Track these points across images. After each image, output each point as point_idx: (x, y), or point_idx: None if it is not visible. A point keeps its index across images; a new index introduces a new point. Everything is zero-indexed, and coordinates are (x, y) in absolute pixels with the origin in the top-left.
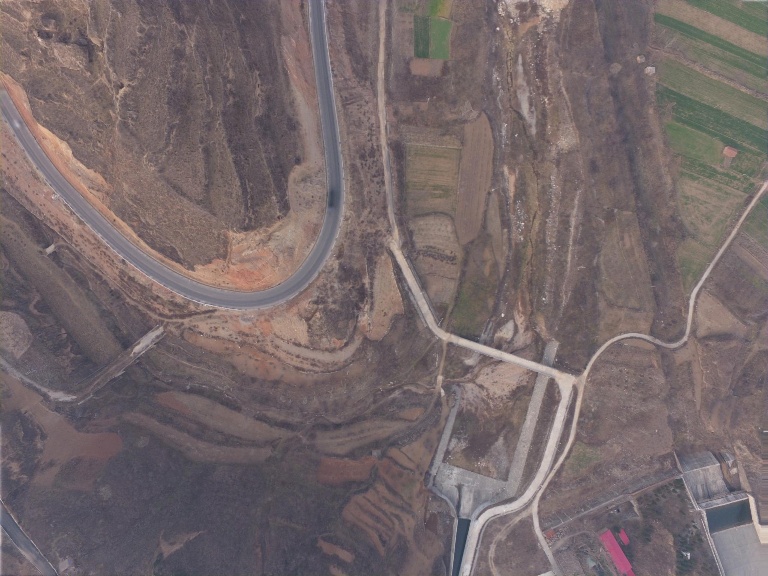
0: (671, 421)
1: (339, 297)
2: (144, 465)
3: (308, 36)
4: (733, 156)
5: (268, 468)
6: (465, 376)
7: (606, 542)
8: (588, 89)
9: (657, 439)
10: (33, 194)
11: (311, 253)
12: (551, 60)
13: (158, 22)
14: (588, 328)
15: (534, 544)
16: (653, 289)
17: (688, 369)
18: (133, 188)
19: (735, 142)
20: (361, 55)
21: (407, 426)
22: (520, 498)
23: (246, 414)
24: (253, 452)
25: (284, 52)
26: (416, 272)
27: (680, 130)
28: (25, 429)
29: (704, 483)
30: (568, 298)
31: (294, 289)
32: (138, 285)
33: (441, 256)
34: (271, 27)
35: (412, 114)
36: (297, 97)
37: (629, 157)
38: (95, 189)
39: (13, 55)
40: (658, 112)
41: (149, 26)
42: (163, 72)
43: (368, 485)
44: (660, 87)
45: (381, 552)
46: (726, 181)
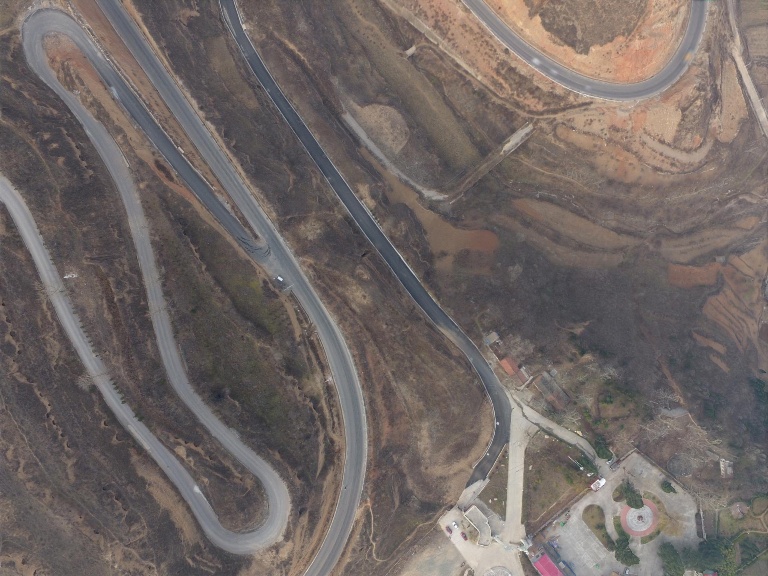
0: None
1: None
2: None
3: None
4: None
5: (623, 272)
6: None
7: None
8: None
9: None
10: None
11: (680, 47)
12: None
13: None
14: None
15: None
16: None
17: None
18: None
19: None
20: None
21: (744, 235)
22: None
23: (610, 213)
24: (606, 258)
25: None
26: None
27: None
28: (414, 220)
29: None
30: None
31: (666, 81)
32: (518, 76)
33: None
34: None
35: None
36: None
37: None
38: None
39: None
40: None
41: None
42: None
43: (718, 288)
44: None
45: (740, 350)
46: None
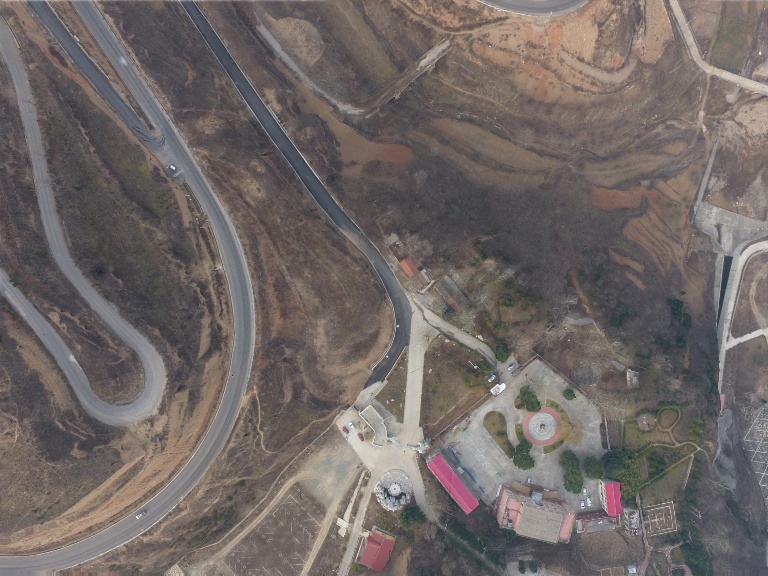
0: None
1: None
2: (437, 173)
3: None
4: None
5: (544, 193)
6: (725, 113)
7: None
8: None
9: None
10: None
11: None
12: None
13: None
14: None
15: None
16: None
17: None
18: None
19: None
20: None
21: (671, 160)
22: None
23: (528, 131)
24: (527, 179)
25: None
26: None
27: None
28: (325, 130)
29: None
30: None
31: None
32: None
33: None
34: None
35: None
36: None
37: None
38: None
39: None
40: None
41: None
42: None
43: (641, 211)
44: None
45: (662, 272)
46: None
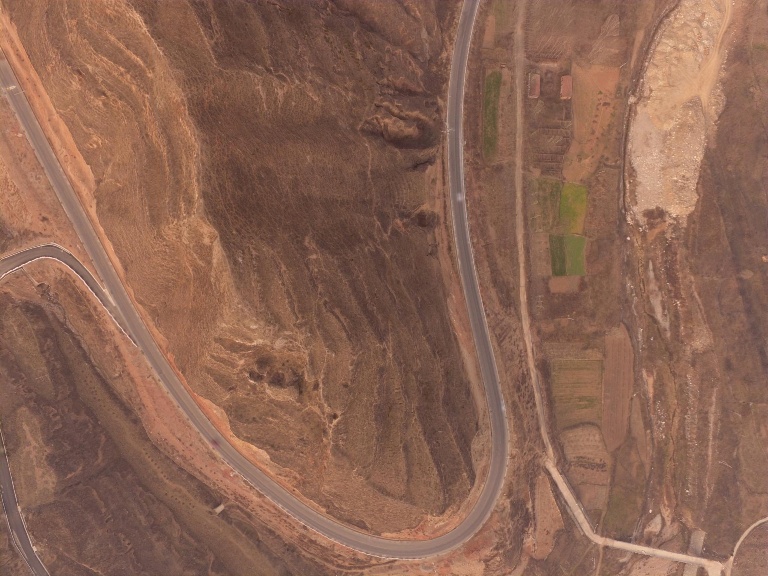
0: None
1: (512, 533)
2: None
3: (459, 279)
4: None
5: None
6: (619, 572)
7: None
8: (719, 291)
9: None
10: (210, 472)
11: (482, 494)
12: (682, 266)
13: (363, 346)
14: (732, 516)
15: None
16: None
17: None
18: (335, 489)
19: None
20: (503, 282)
21: None
22: None
23: None
24: None
25: (451, 315)
26: (570, 484)
27: None
28: None
29: None
30: (712, 490)
31: (469, 531)
32: (319, 546)
33: (591, 465)
34: (441, 298)
35: (554, 331)
36: (464, 354)
37: (760, 352)
38: (283, 475)
39: (219, 389)
40: None
41: (357, 355)
42: (370, 392)
43: None
44: None
45: None
46: None
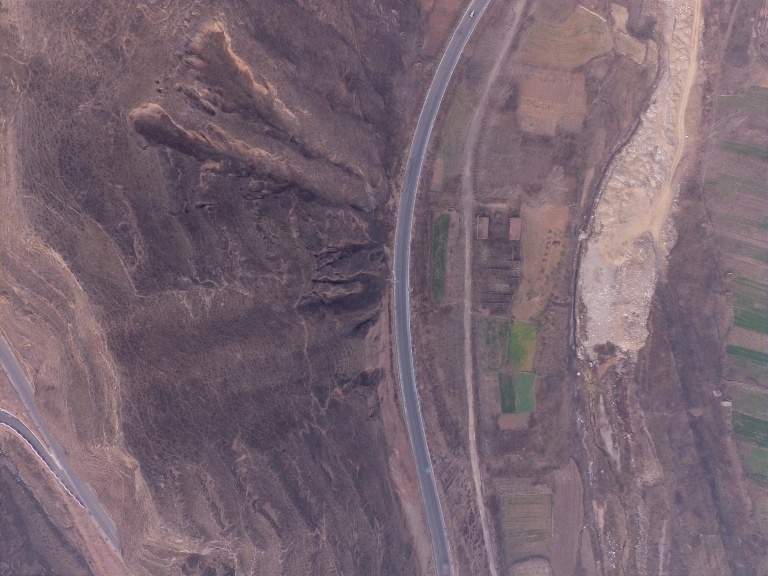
0: None
1: None
2: None
3: (405, 426)
4: None
5: None
6: None
7: None
8: (669, 426)
9: None
10: None
11: None
12: (632, 402)
13: (294, 536)
14: None
15: None
16: None
17: None
18: None
19: None
20: (452, 422)
21: None
22: None
23: None
24: None
25: (393, 474)
26: None
27: (756, 452)
28: None
29: None
30: None
31: None
32: None
33: None
34: (381, 462)
35: (503, 467)
36: (407, 510)
37: (711, 484)
38: None
39: None
40: (736, 440)
41: (288, 547)
42: None
43: None
44: (738, 422)
45: None
46: None
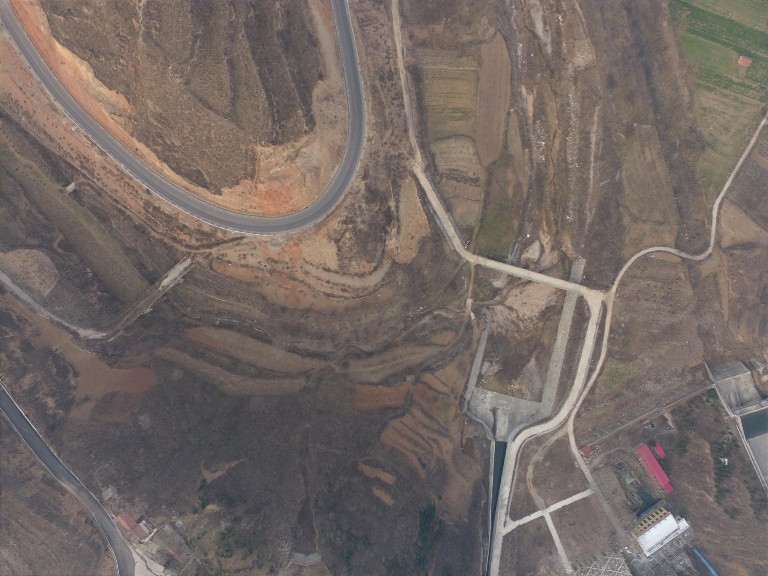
0: (700, 333)
1: (367, 218)
2: (179, 397)
3: None
4: (748, 65)
5: (303, 398)
6: (494, 298)
7: (642, 457)
8: (601, 4)
9: (688, 351)
10: (52, 127)
11: (336, 175)
12: None
13: None
14: (614, 243)
15: (571, 463)
16: (676, 201)
17: (714, 280)
18: (158, 105)
19: (749, 51)
20: None
21: (439, 351)
22: (555, 417)
23: (279, 343)
24: (287, 383)
25: None
26: (440, 195)
27: (694, 42)
28: (57, 366)
29: (736, 392)
30: (592, 215)
31: (321, 212)
32: (164, 215)
33: (464, 178)
34: None
35: (427, 37)
36: (315, 15)
37: (646, 71)
38: (117, 114)
39: None
40: (672, 24)
41: None
42: None
43: (404, 410)
44: None
45: (421, 475)
46: (742, 91)
